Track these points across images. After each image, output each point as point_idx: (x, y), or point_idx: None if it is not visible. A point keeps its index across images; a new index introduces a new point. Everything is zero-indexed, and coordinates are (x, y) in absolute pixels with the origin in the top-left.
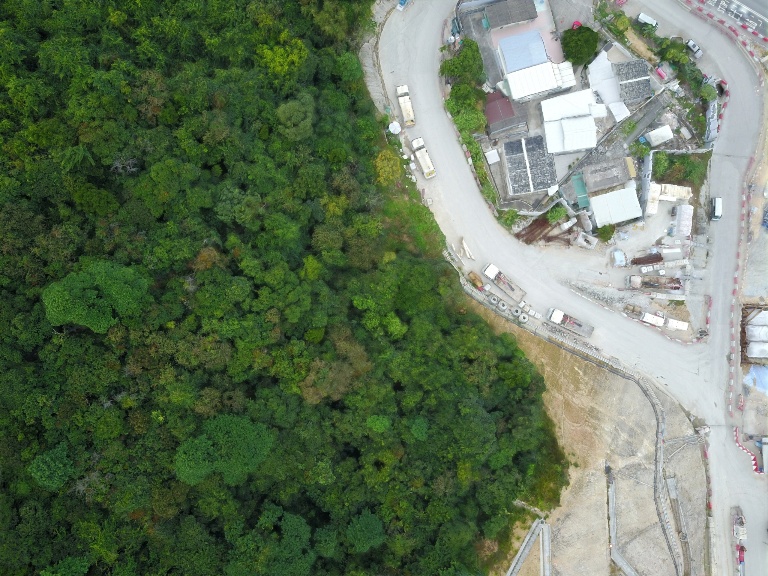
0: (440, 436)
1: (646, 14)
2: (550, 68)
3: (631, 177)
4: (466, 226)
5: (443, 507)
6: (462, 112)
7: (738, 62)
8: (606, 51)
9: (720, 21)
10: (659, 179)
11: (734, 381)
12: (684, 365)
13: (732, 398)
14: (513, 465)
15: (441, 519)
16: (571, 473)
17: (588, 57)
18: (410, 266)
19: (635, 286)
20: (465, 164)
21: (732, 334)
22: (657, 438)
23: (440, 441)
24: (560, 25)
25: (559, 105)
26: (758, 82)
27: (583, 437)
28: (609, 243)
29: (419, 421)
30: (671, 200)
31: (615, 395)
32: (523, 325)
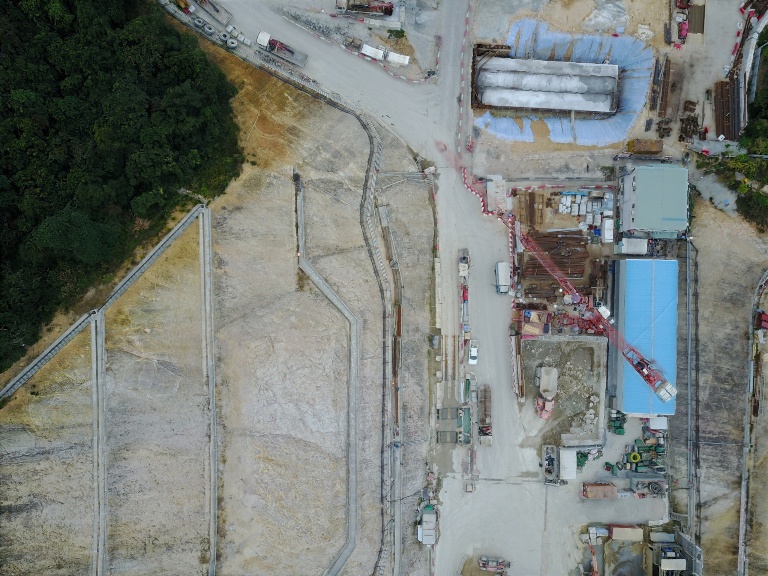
0: (89, 111)
1: None
2: None
3: None
4: None
5: (79, 172)
6: None
7: None
8: None
9: None
10: None
11: (464, 123)
12: (411, 105)
13: (461, 140)
14: (169, 145)
15: (75, 182)
16: (245, 168)
17: None
18: None
19: (341, 5)
20: None
21: (462, 75)
22: (369, 166)
23: (88, 116)
24: None
25: None
26: None
27: (272, 145)
28: None
29: (69, 97)
30: None
31: (326, 122)
32: (232, 51)
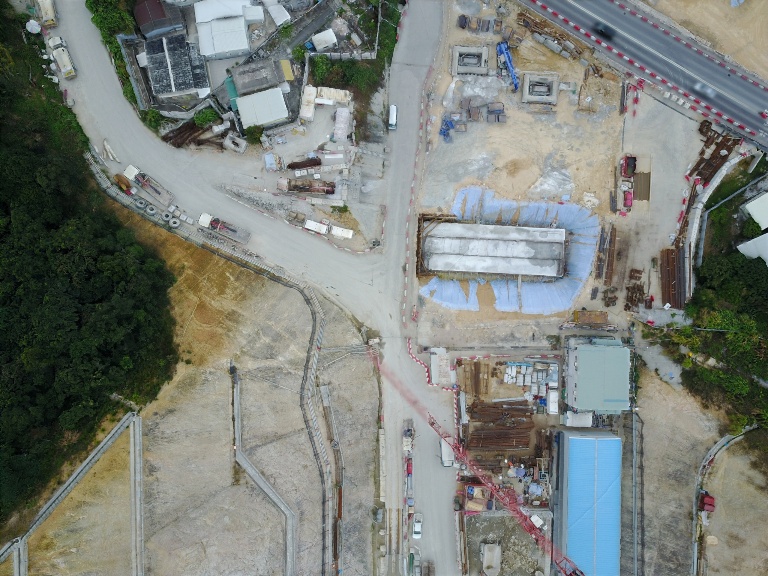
0: (19, 324)
1: None
2: None
3: (285, 79)
4: (111, 128)
5: (6, 393)
6: (100, 10)
7: None
8: None
9: None
10: (320, 83)
11: (409, 292)
12: (356, 275)
13: (407, 309)
14: (99, 355)
15: (2, 404)
16: (179, 369)
17: None
18: (8, 156)
19: (282, 188)
20: (110, 65)
21: (407, 244)
22: (311, 345)
23: (18, 329)
24: None
25: (212, 7)
26: None
27: (210, 337)
28: (264, 147)
29: None
30: (328, 103)
31: (268, 301)
32: (174, 230)
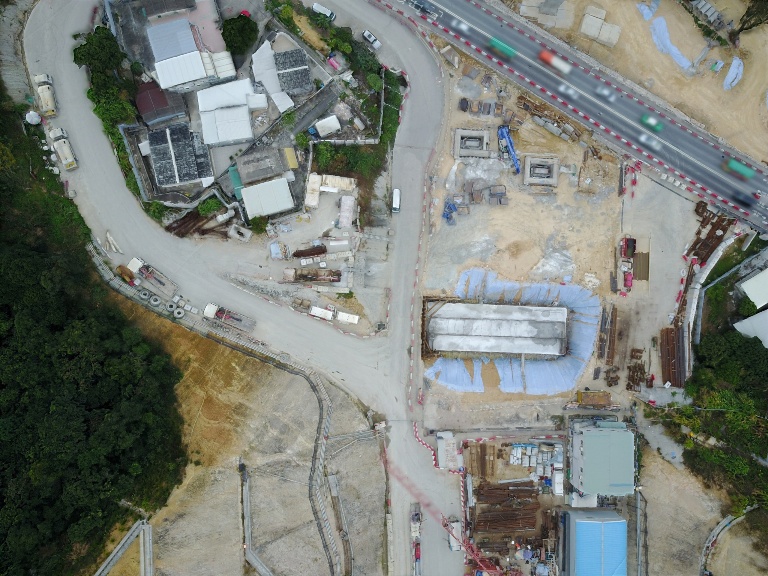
0: (25, 435)
1: (325, 4)
2: (198, 57)
3: (290, 168)
4: (113, 219)
5: (13, 510)
6: (103, 102)
7: (419, 53)
8: (269, 41)
9: (399, 12)
10: (325, 170)
11: (414, 375)
12: (362, 359)
13: (412, 392)
14: (108, 464)
15: (9, 522)
16: (188, 471)
17: (246, 46)
18: (11, 259)
19: (288, 279)
20: (112, 155)
21: (412, 327)
22: (318, 434)
23: (24, 441)
24: (228, 15)
25: (215, 95)
26: (439, 73)
27: (218, 434)
28: (269, 235)
29: (4, 420)
30: (333, 191)
31: (275, 391)
32: (179, 320)
